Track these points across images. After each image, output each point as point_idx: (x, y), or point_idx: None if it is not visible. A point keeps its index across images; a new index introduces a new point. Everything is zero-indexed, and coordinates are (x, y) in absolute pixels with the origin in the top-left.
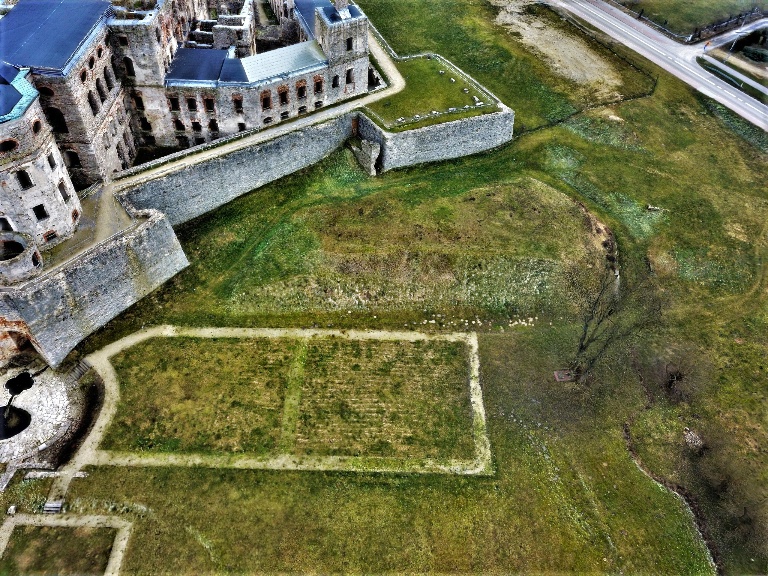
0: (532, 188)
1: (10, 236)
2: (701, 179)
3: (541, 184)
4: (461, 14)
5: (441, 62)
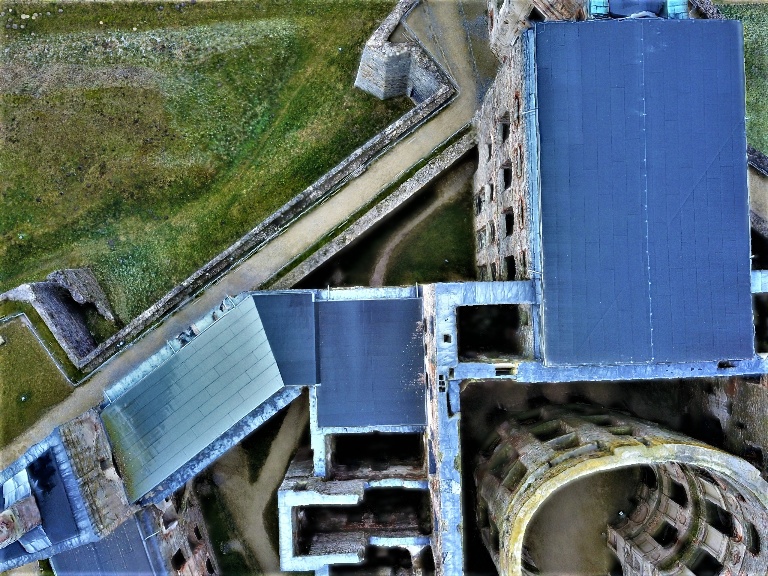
0: None
1: None
2: None
3: None
4: None
5: None
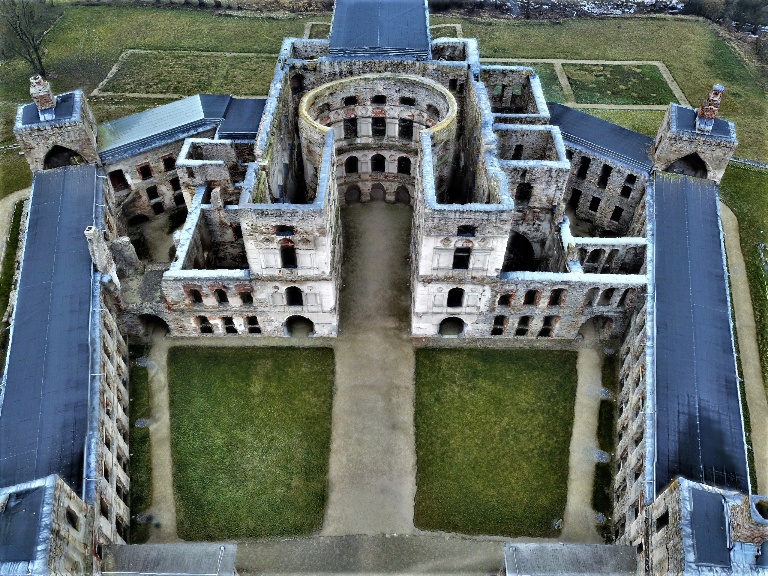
0: None
1: None
2: None
3: None
4: None
5: None
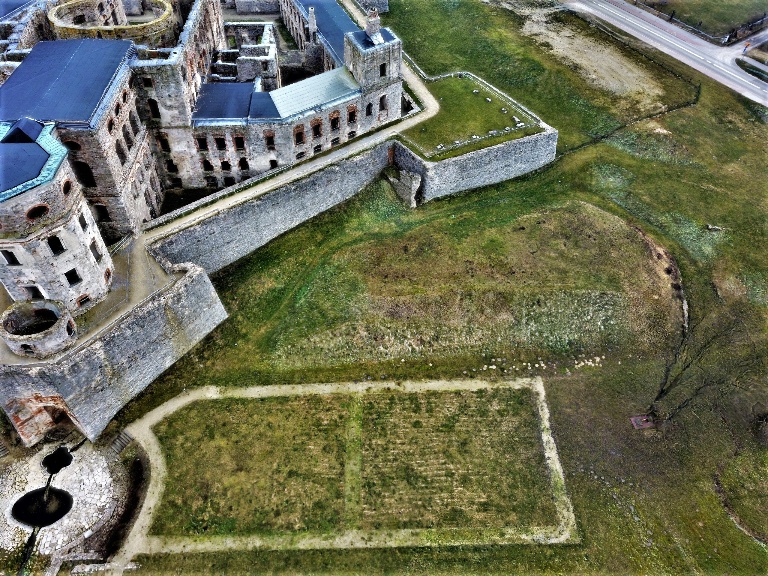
0: (583, 213)
1: (41, 304)
2: (759, 193)
3: (592, 207)
4: (485, 26)
5: (473, 80)
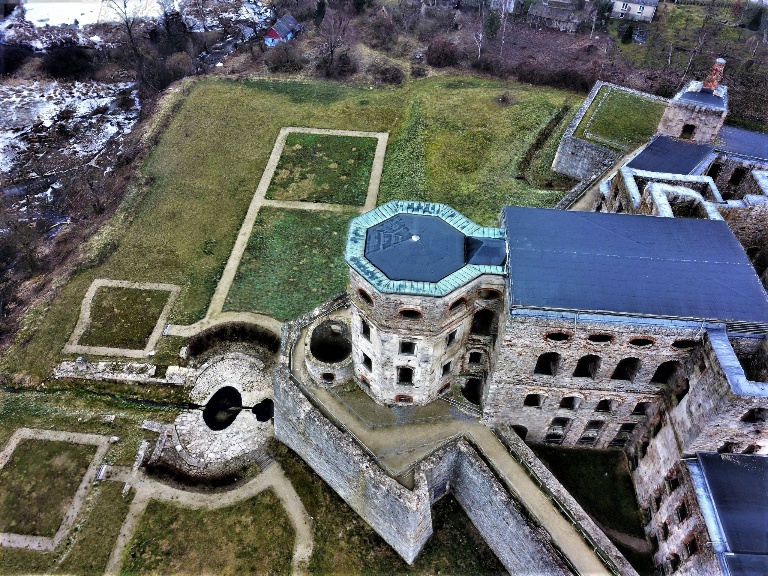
0: None
1: None
2: None
3: None
4: None
5: None
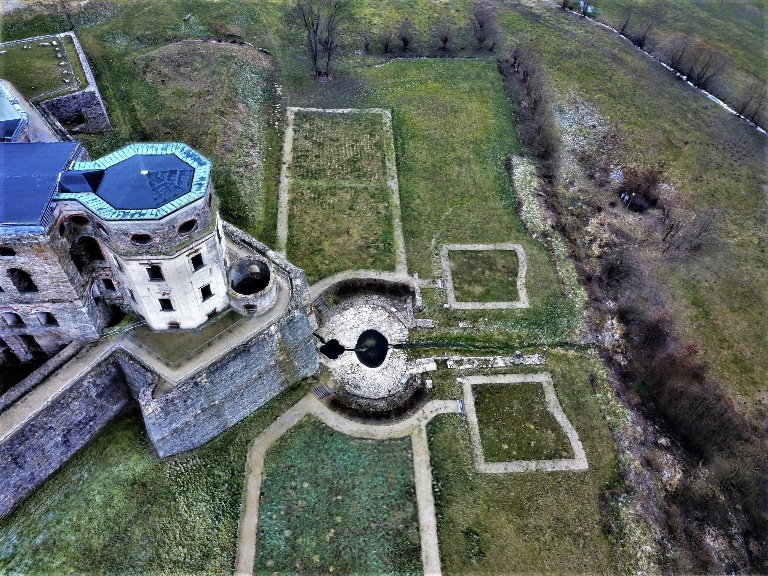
0: (155, 55)
1: (230, 278)
2: None
3: None
4: None
5: None
